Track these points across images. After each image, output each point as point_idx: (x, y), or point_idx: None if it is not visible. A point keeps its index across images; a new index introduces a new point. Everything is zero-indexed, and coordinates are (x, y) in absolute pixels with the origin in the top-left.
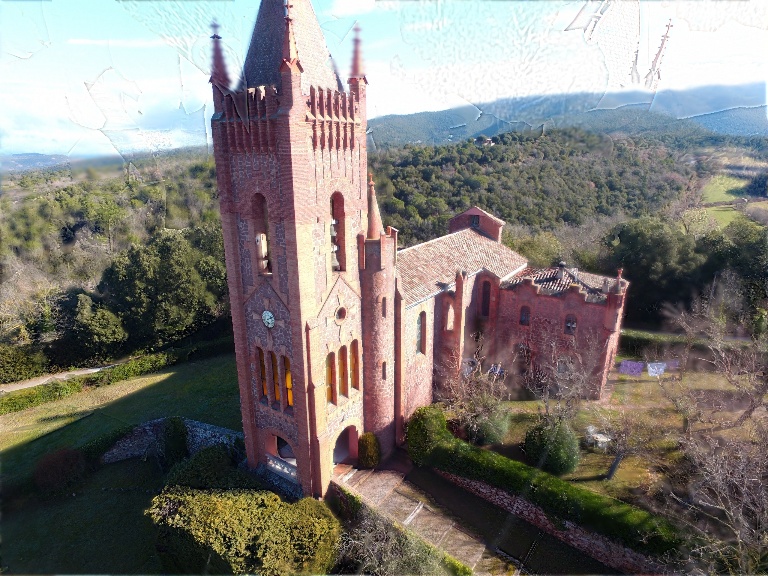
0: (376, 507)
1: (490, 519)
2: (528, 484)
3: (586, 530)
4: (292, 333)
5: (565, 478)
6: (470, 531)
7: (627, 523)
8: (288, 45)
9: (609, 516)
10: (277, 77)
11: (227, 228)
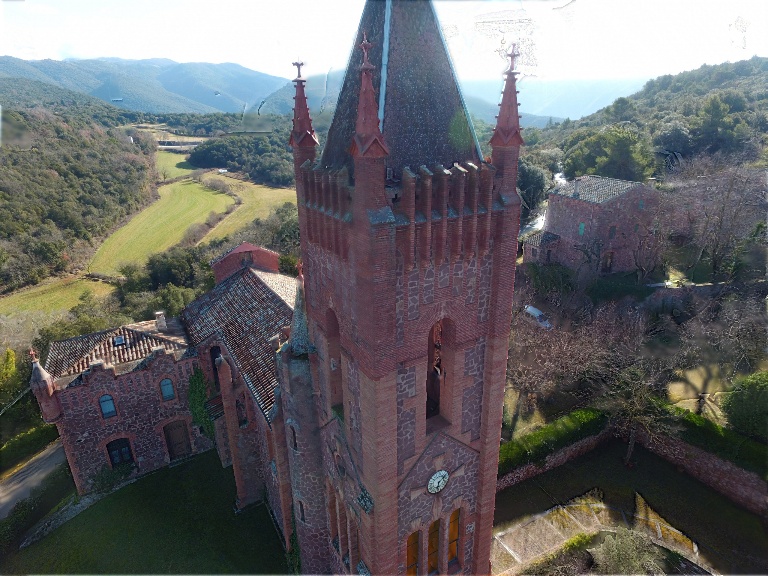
0: (517, 569)
1: (518, 500)
2: (526, 453)
3: (555, 453)
4: (485, 470)
5: (509, 434)
6: (528, 519)
7: (573, 429)
8: (515, 110)
9: (566, 433)
10: (456, 146)
11: (389, 396)
